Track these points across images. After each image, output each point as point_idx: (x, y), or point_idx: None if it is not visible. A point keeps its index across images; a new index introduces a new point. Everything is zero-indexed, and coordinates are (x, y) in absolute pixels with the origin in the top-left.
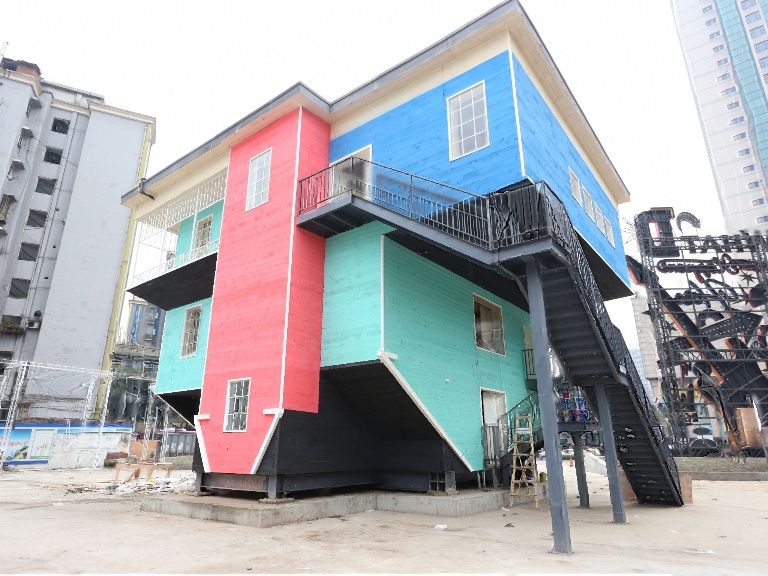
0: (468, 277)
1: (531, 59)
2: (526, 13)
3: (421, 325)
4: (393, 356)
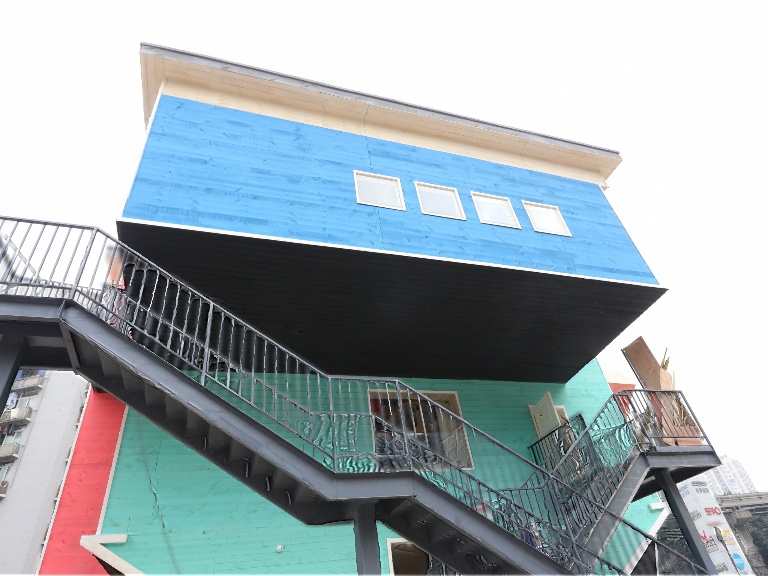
0: (346, 372)
1: (231, 88)
2: (175, 50)
3: (215, 471)
4: (115, 538)
